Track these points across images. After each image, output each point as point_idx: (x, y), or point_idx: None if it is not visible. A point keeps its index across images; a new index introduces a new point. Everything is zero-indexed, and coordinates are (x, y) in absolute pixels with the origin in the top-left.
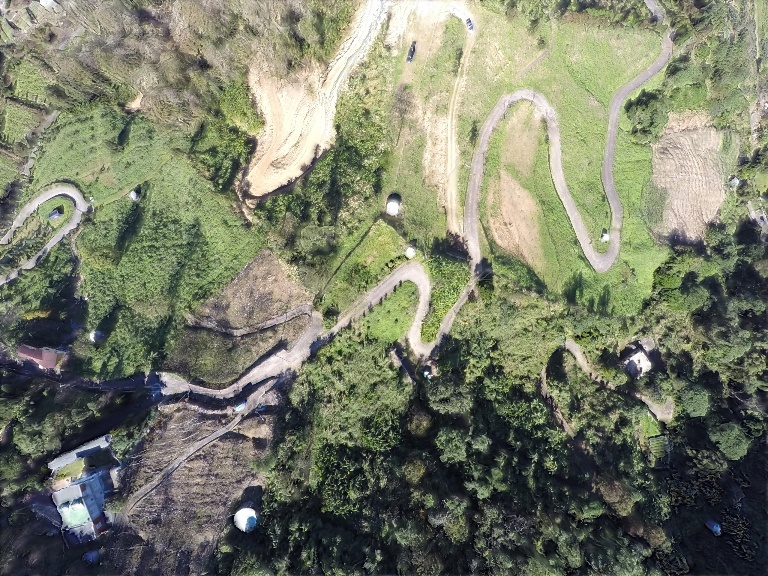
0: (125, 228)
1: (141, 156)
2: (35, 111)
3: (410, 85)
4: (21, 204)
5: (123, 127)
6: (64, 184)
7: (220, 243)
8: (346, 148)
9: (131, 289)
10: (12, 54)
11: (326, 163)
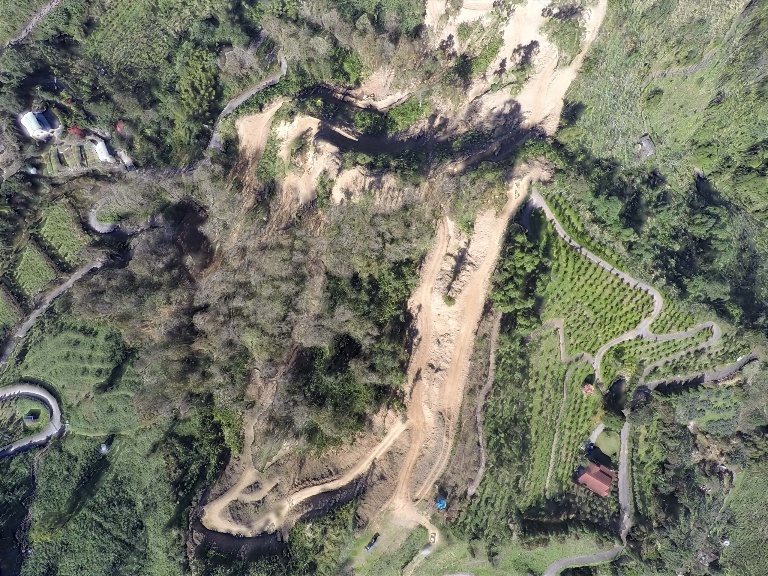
0: (84, 482)
1: (125, 407)
2: (53, 264)
3: (359, 569)
4: (5, 378)
5: (120, 361)
6: (48, 392)
7: (155, 567)
8: (287, 575)
9: (65, 565)
10: (52, 187)
11: (267, 570)
